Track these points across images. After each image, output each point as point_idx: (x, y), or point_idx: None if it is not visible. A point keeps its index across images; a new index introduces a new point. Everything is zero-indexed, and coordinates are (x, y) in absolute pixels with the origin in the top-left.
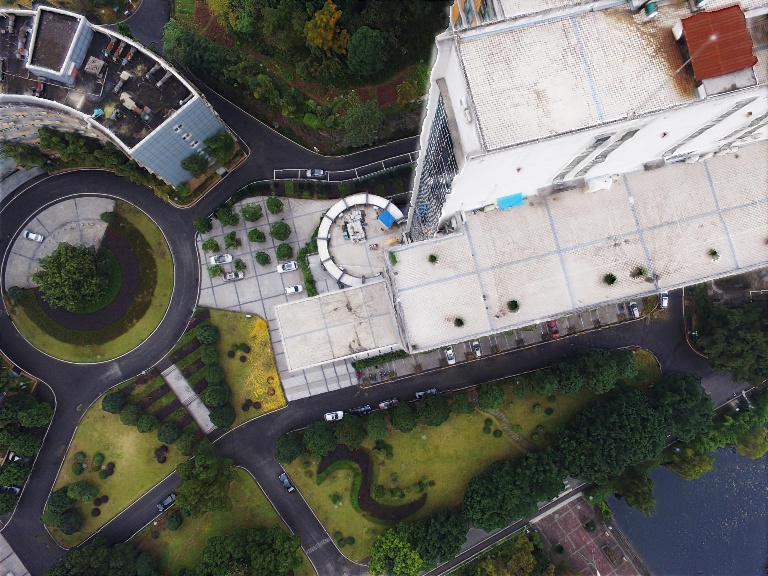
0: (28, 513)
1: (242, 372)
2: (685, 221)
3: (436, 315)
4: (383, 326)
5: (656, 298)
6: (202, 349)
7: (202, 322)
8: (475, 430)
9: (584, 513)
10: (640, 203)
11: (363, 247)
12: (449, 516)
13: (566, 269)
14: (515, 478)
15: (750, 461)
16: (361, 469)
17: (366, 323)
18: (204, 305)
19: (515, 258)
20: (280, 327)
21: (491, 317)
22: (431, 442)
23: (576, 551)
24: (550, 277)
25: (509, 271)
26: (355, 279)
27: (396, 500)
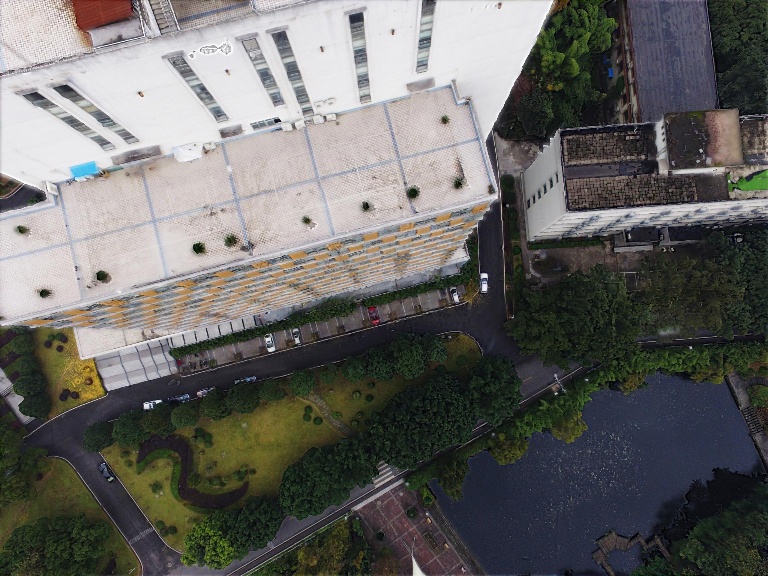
0: None
1: (59, 362)
2: (283, 189)
3: (27, 286)
4: None
5: (477, 283)
6: (13, 339)
7: None
8: (295, 417)
9: (407, 500)
10: (238, 172)
11: None
12: (261, 504)
13: (160, 239)
14: (325, 464)
15: (576, 446)
16: (181, 458)
17: None
18: None
19: (109, 228)
20: None
21: (82, 288)
22: (251, 430)
23: (398, 538)
24: (144, 247)
25: (102, 241)
26: None
27: (217, 489)
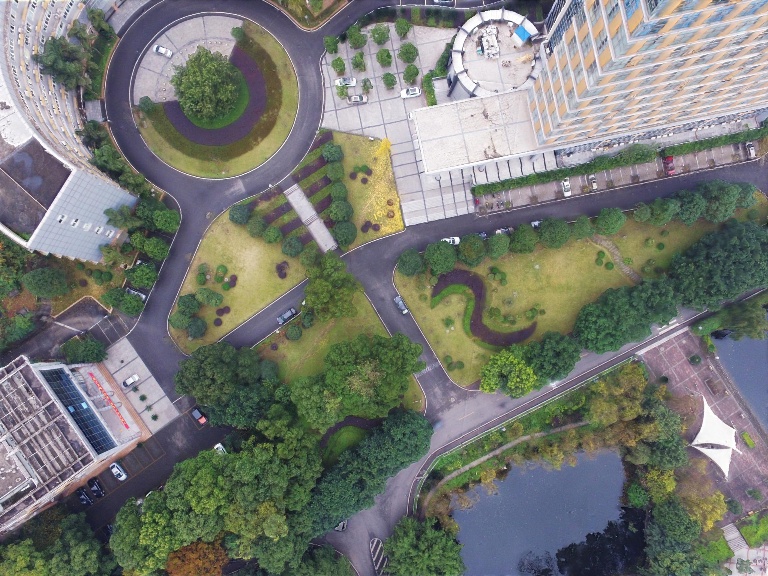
0: (152, 320)
1: (363, 194)
2: None
3: None
4: (518, 134)
5: None
6: (329, 164)
7: (325, 143)
8: (587, 262)
9: (689, 347)
10: None
11: (495, 63)
12: (563, 337)
13: None
14: (631, 300)
15: None
16: (474, 295)
17: (502, 130)
18: (327, 127)
19: None
20: (418, 130)
21: None
22: (543, 272)
23: (679, 383)
24: None
25: None
26: (488, 92)
27: (506, 327)
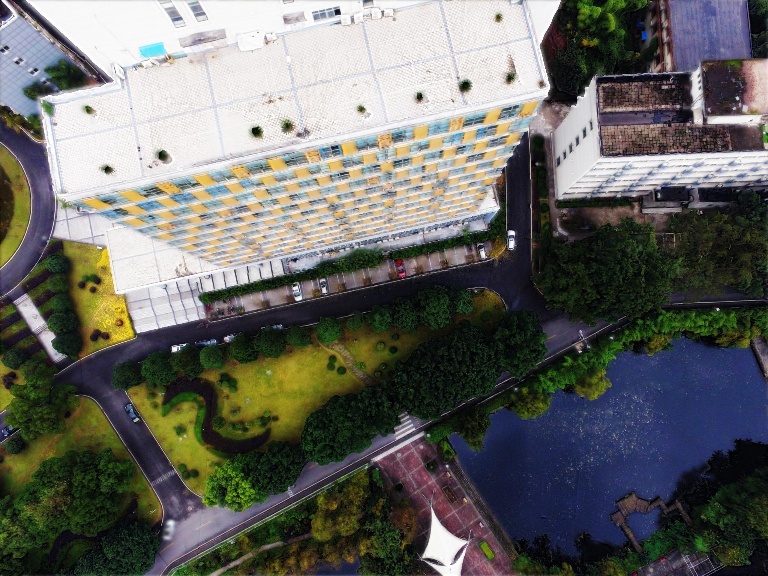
0: None
1: (91, 302)
2: (339, 80)
3: (92, 165)
4: None
5: (504, 240)
6: (48, 277)
7: (55, 253)
8: (319, 366)
9: (427, 453)
10: (297, 62)
11: None
12: (283, 448)
13: (220, 123)
14: (348, 411)
15: (598, 407)
16: (205, 402)
17: None
18: (58, 237)
19: (172, 112)
20: (109, 250)
21: (144, 167)
22: (276, 377)
23: (417, 491)
24: (204, 131)
25: (165, 124)
26: None
27: (240, 434)
